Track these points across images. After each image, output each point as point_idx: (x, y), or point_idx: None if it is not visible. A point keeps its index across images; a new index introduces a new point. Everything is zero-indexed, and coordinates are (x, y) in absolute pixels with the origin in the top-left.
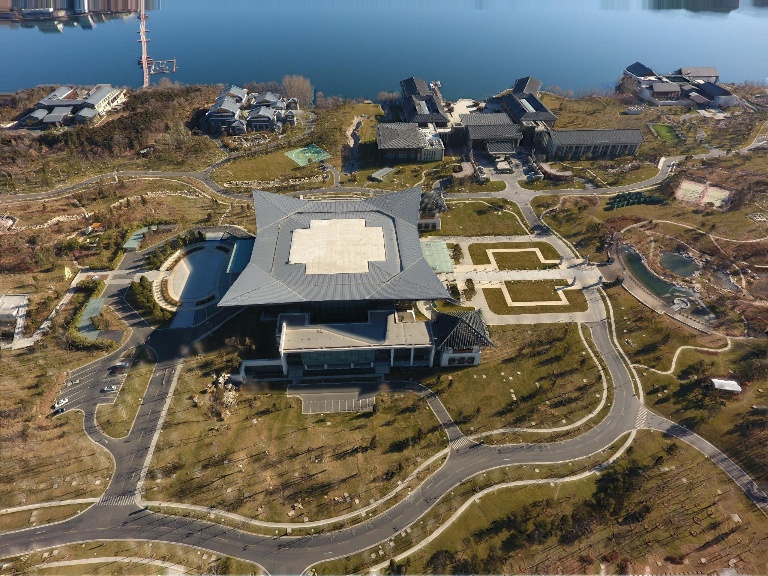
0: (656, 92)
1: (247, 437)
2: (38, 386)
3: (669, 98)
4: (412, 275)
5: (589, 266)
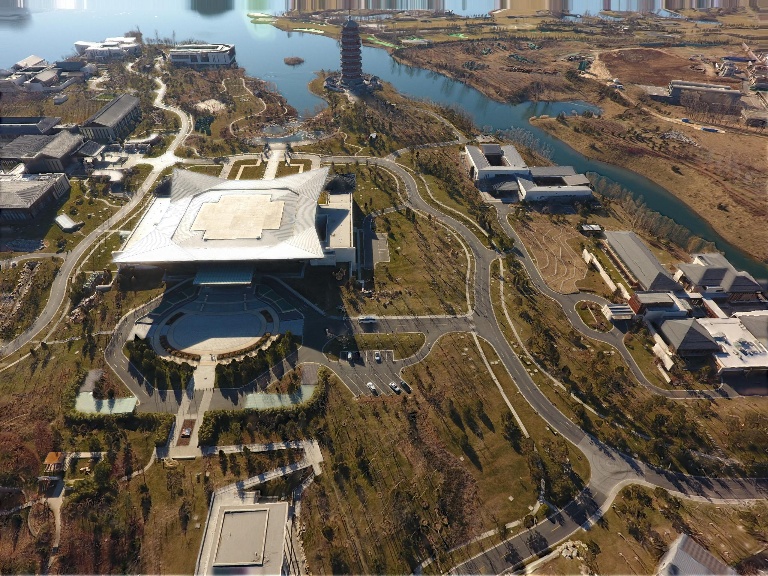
0: (46, 81)
1: (414, 278)
2: (376, 413)
3: (54, 83)
4: (295, 183)
5: (269, 152)
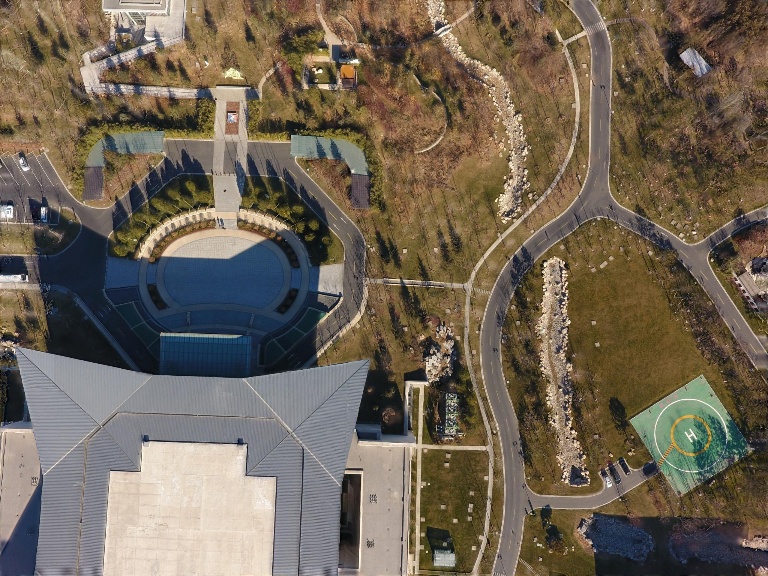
0: None
1: None
2: None
3: None
4: None
5: None
